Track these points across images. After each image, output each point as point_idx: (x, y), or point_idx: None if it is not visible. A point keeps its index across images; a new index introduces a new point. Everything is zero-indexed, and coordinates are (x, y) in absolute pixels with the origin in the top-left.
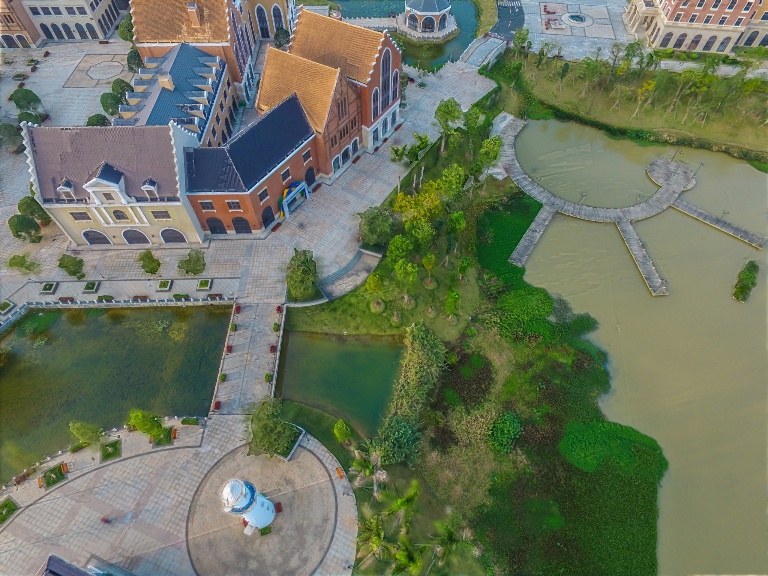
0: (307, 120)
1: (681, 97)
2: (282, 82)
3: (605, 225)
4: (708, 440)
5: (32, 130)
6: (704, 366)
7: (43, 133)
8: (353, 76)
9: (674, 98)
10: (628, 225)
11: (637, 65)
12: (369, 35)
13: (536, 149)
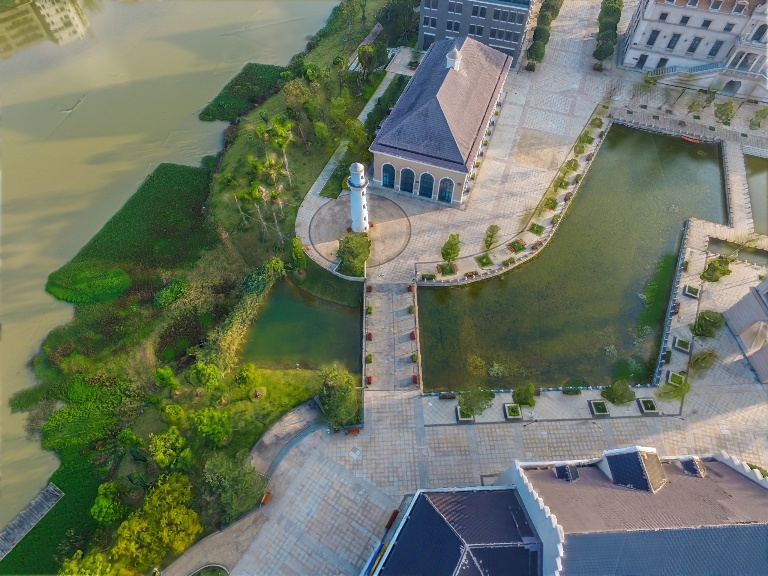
0: None
1: None
2: None
3: None
4: (1, 290)
5: None
6: None
7: None
8: None
9: None
10: None
11: None
12: None
13: None
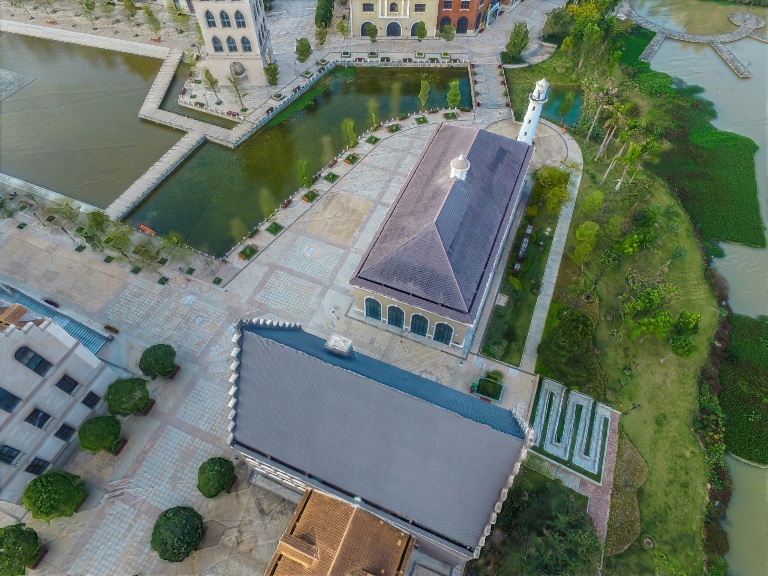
0: None
1: None
2: None
3: (702, 45)
4: None
5: None
6: None
7: None
8: None
9: None
10: (719, 44)
11: None
12: None
13: (645, 6)
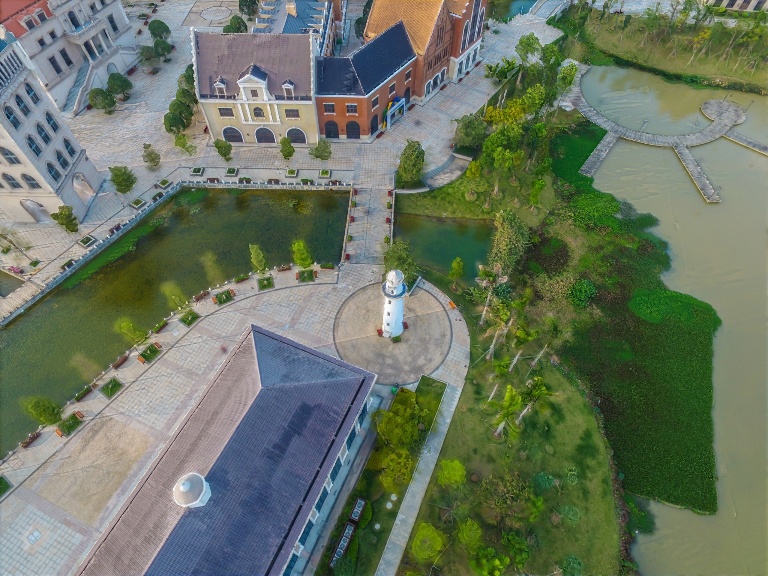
0: (410, 44)
1: (734, 46)
2: (390, 11)
3: (663, 149)
4: (756, 307)
5: (198, 35)
6: (752, 256)
7: (206, 37)
8: (449, 9)
9: (727, 47)
10: (684, 149)
11: (692, 21)
12: None
13: (599, 89)
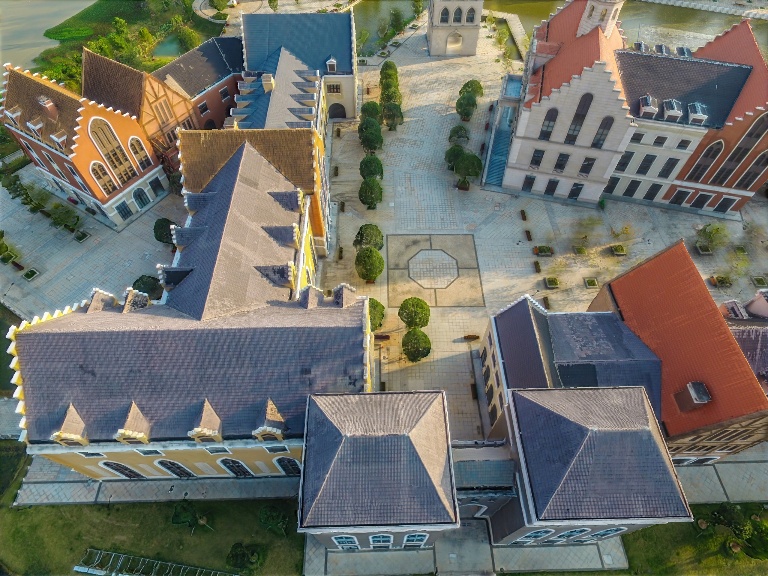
0: None
1: None
2: None
3: None
4: (17, 35)
5: None
6: None
7: None
8: None
9: None
10: None
11: None
12: (27, 75)
13: None
